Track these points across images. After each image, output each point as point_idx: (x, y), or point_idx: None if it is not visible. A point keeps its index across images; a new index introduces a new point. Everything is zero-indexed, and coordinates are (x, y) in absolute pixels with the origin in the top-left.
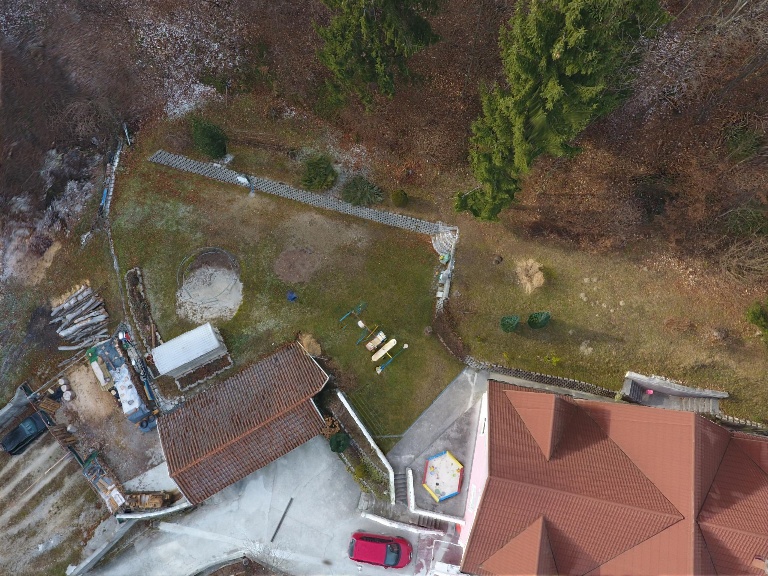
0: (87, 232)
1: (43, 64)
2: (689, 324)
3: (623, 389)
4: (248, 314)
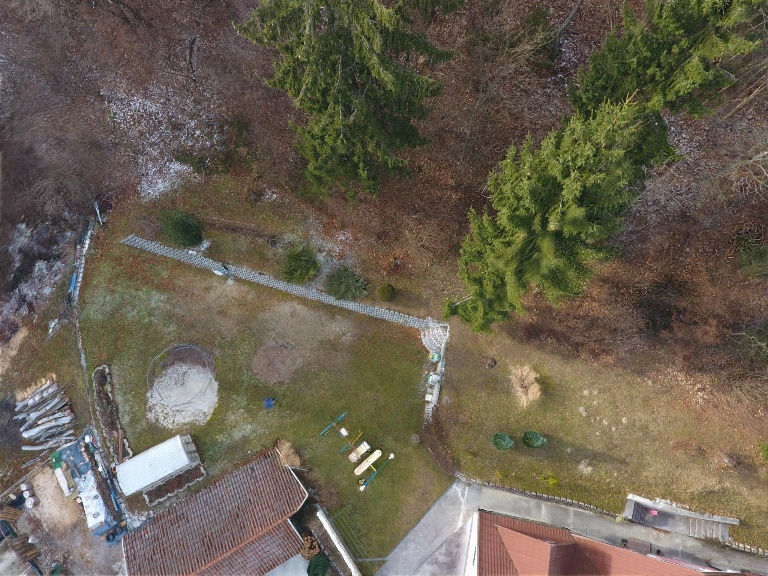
0: (55, 318)
1: (11, 136)
2: (697, 448)
3: (625, 512)
4: (223, 418)
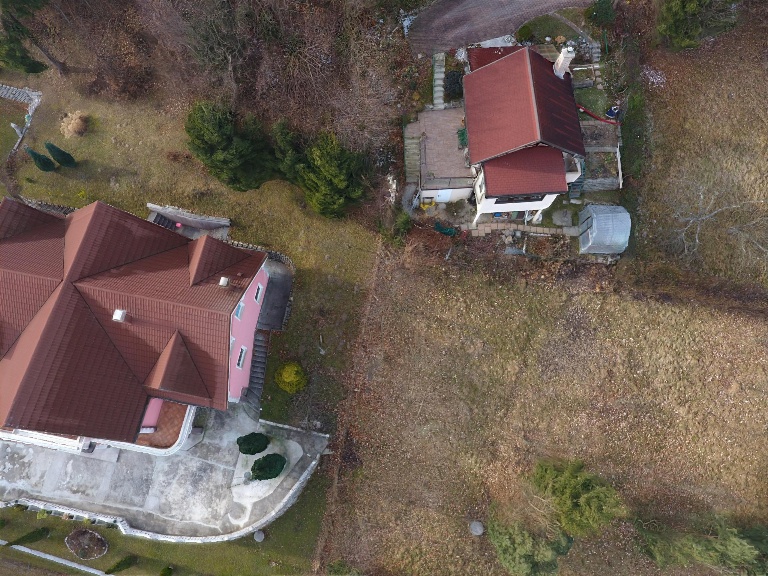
0: None
1: None
2: (184, 155)
3: None
4: None
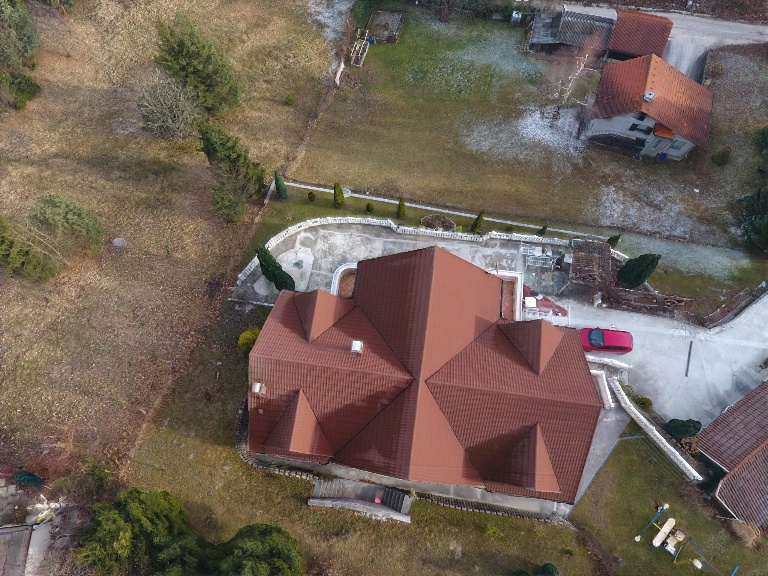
0: None
1: None
2: None
3: (411, 502)
4: None
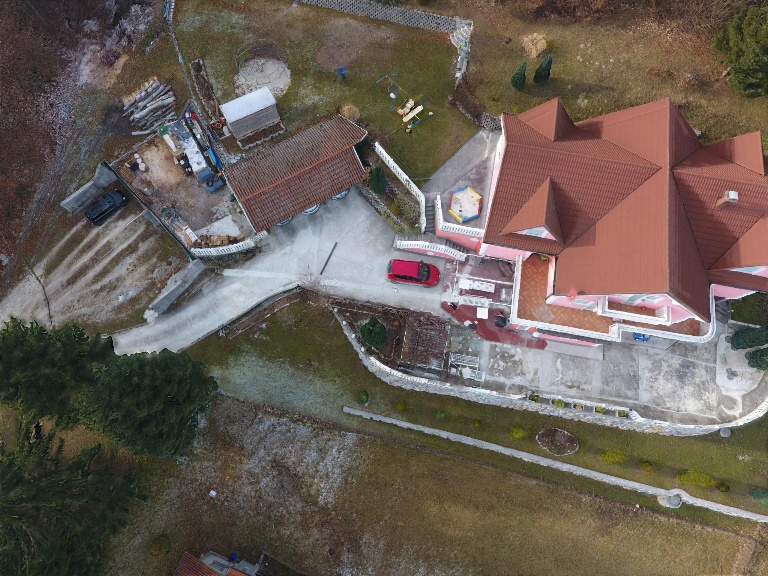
0: None
1: None
2: (667, 70)
3: None
4: (296, 92)
